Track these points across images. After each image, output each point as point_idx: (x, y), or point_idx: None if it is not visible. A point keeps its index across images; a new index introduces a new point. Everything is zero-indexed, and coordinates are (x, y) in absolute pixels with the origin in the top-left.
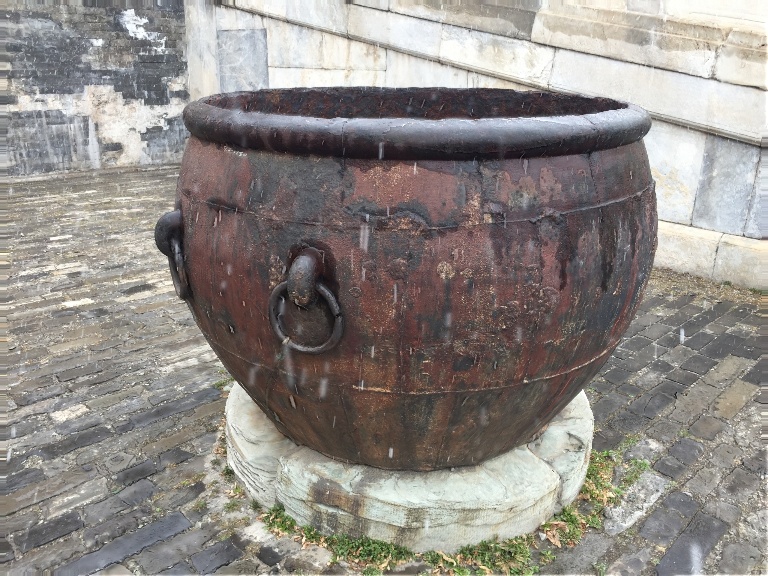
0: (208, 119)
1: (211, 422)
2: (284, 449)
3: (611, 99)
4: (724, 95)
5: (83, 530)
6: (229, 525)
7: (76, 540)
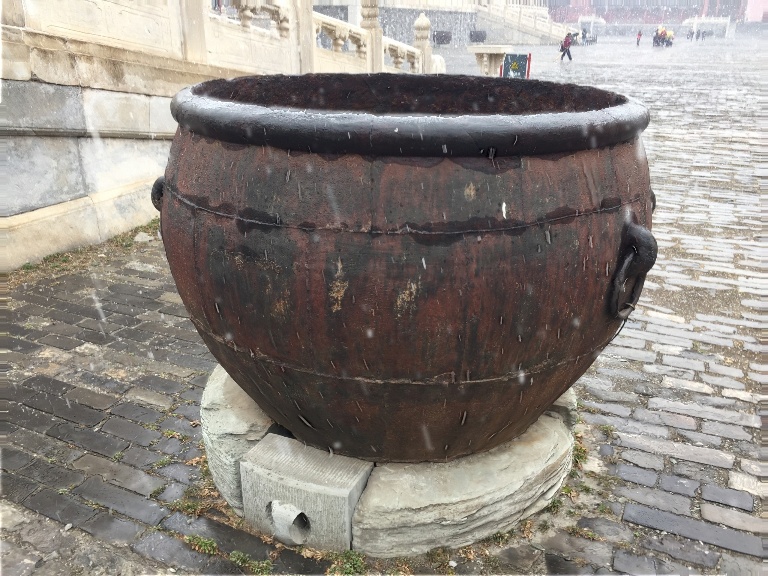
0: (643, 114)
1: (479, 573)
2: (547, 420)
3: None
4: None
5: (712, 572)
6: (604, 481)
7: (725, 567)
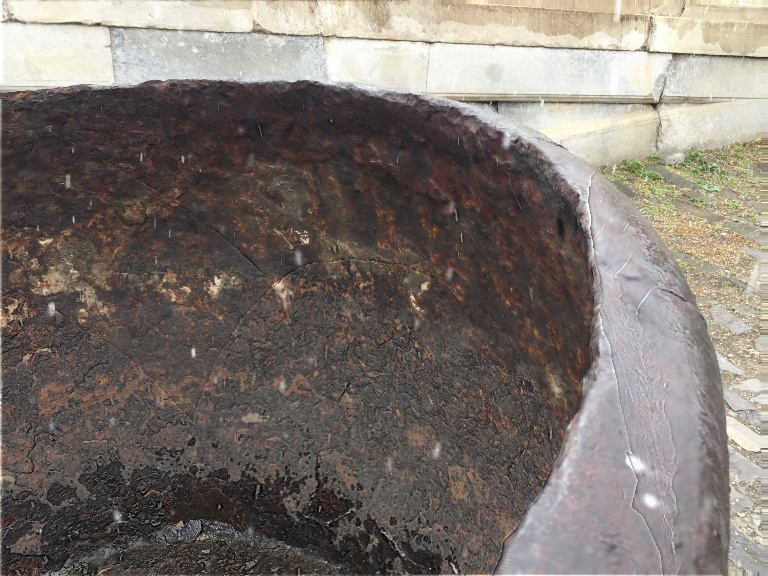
0: None
1: None
2: None
3: (201, 80)
4: (39, 40)
5: None
6: None
7: None
